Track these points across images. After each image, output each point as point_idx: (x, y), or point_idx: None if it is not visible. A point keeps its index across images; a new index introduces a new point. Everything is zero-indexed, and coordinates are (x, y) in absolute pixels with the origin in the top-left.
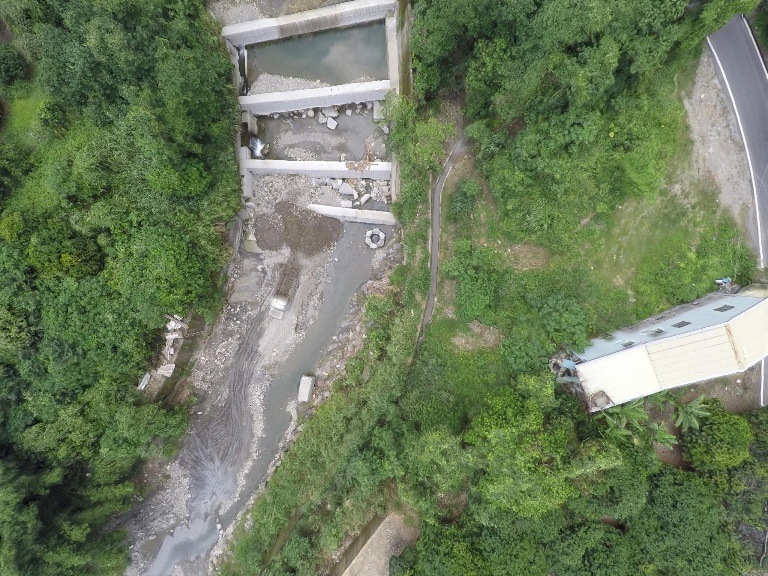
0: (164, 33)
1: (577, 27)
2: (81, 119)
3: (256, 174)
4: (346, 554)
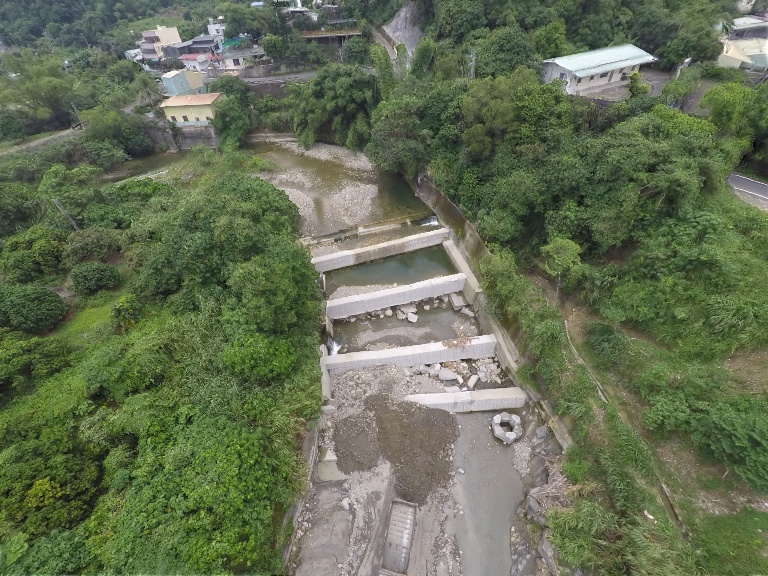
0: None
1: (651, 153)
2: (158, 311)
3: (334, 374)
4: None
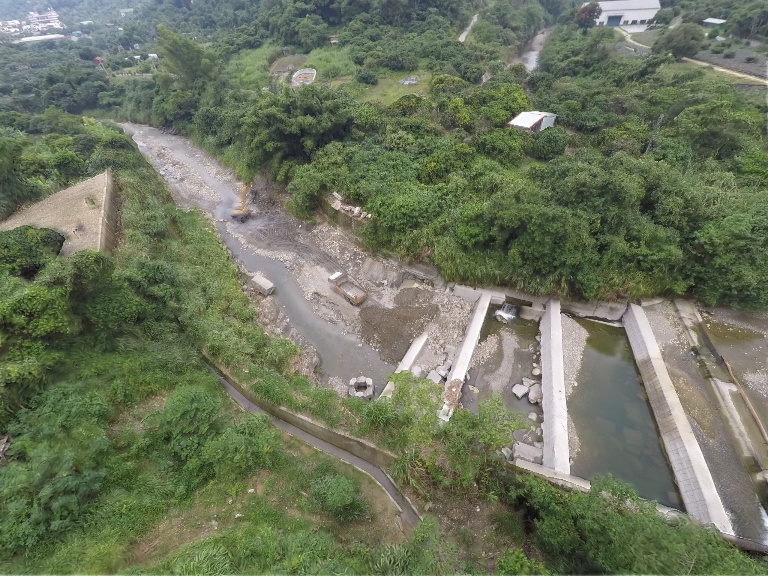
0: (611, 233)
1: None
2: None
3: None
4: (113, 244)
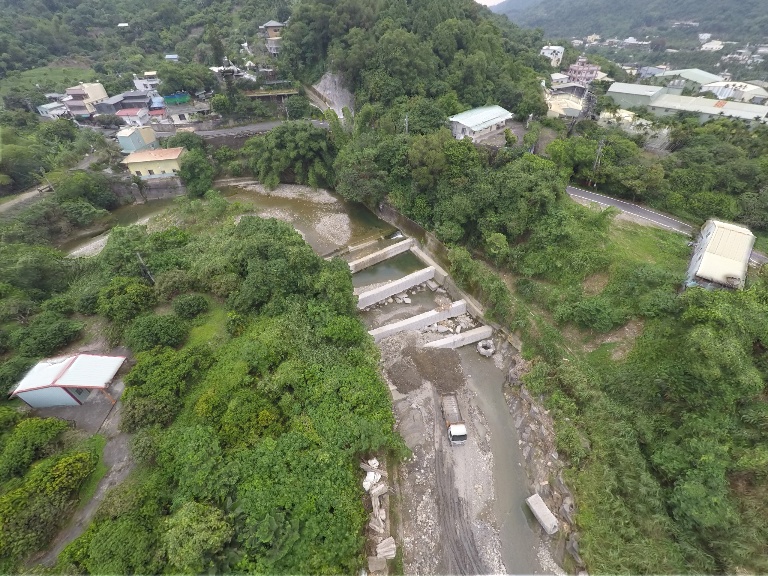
0: None
1: (528, 181)
2: None
3: None
4: None
